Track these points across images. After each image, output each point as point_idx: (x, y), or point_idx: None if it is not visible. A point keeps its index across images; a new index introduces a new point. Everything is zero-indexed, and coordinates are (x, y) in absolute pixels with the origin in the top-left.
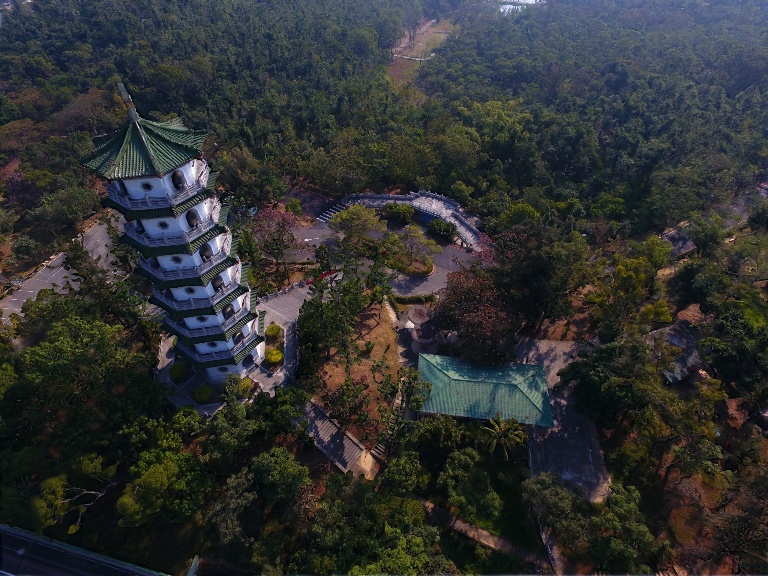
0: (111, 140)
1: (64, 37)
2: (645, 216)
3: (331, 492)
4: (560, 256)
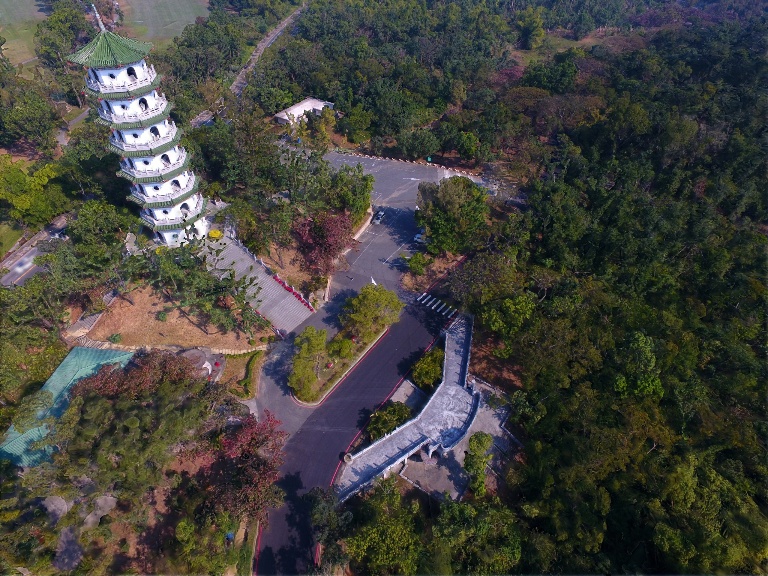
0: None
1: (704, 56)
2: None
3: None
4: None
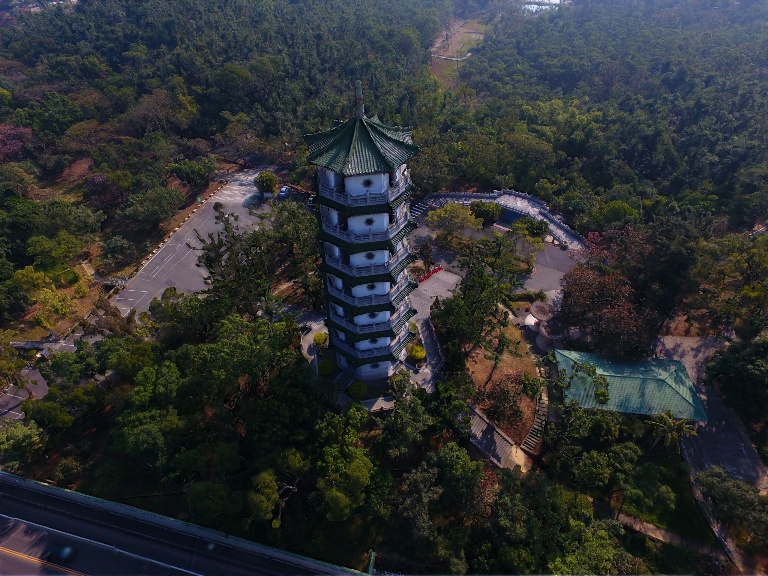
0: (336, 137)
1: (116, 38)
2: (735, 213)
3: (508, 486)
4: (715, 251)
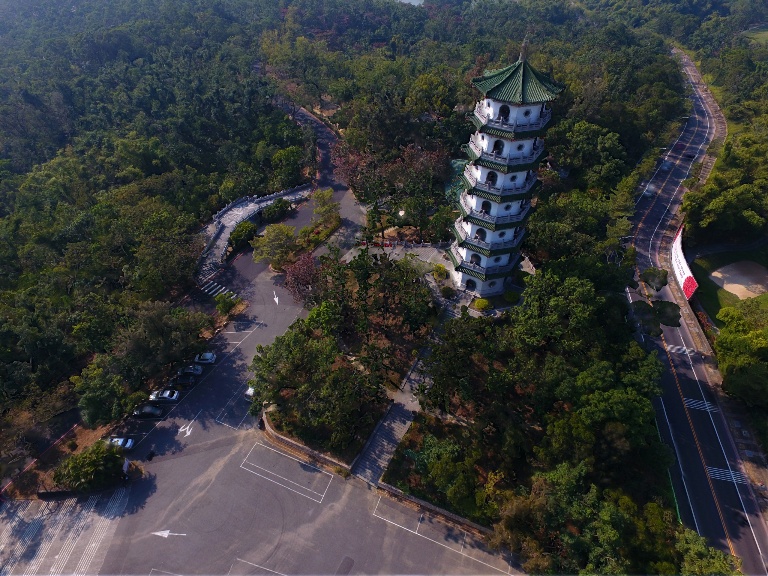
0: None
1: None
2: None
3: None
4: (425, 94)
